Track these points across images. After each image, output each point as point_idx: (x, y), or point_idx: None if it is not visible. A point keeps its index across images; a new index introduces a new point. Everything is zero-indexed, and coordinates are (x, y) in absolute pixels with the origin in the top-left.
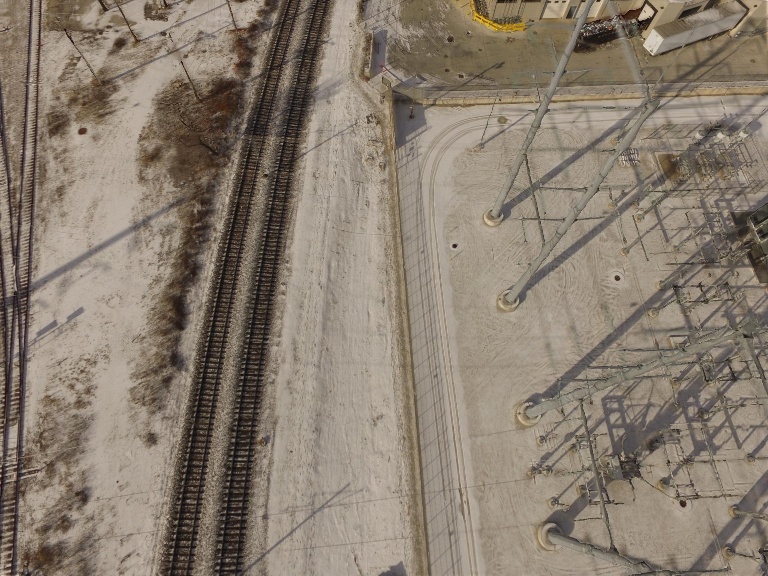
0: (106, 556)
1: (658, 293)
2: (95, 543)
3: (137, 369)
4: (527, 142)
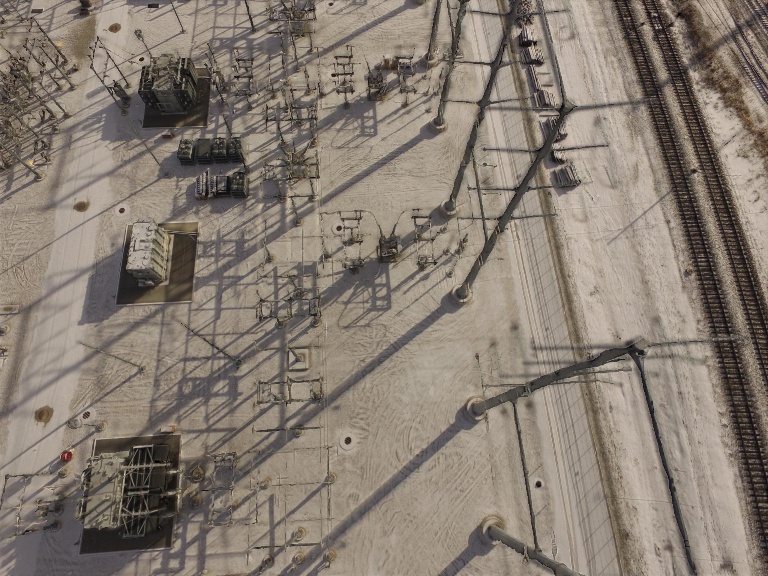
0: None
1: (305, 422)
2: None
3: None
4: None
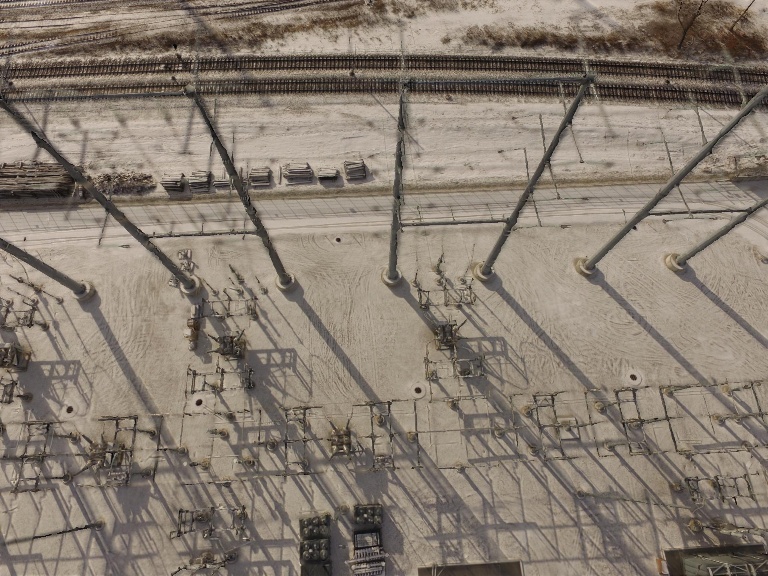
0: (380, 31)
1: None
2: (387, 25)
3: (491, 27)
4: (765, 199)
